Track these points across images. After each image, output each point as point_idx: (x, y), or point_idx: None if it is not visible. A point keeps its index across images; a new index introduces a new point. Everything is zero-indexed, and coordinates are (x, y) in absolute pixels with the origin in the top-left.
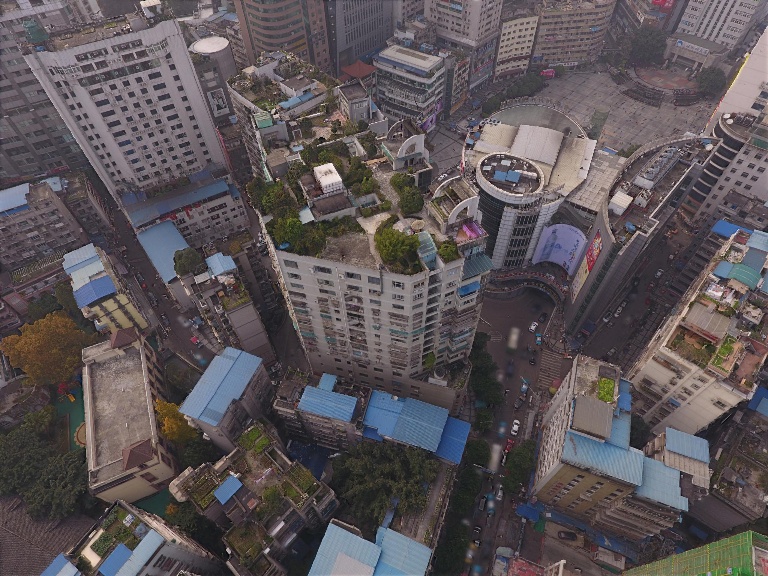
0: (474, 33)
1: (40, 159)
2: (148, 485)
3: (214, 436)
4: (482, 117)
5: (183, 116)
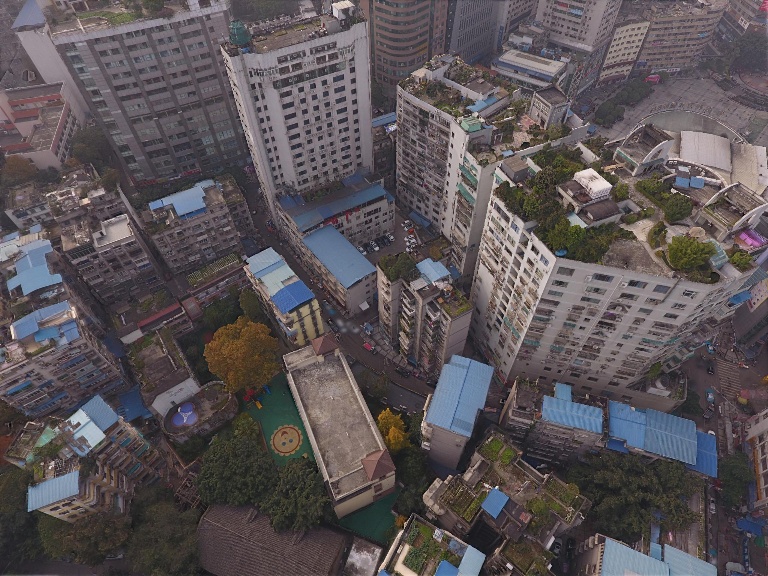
0: (592, 38)
1: (177, 162)
2: (371, 496)
3: (441, 446)
4: (595, 122)
5: (350, 119)
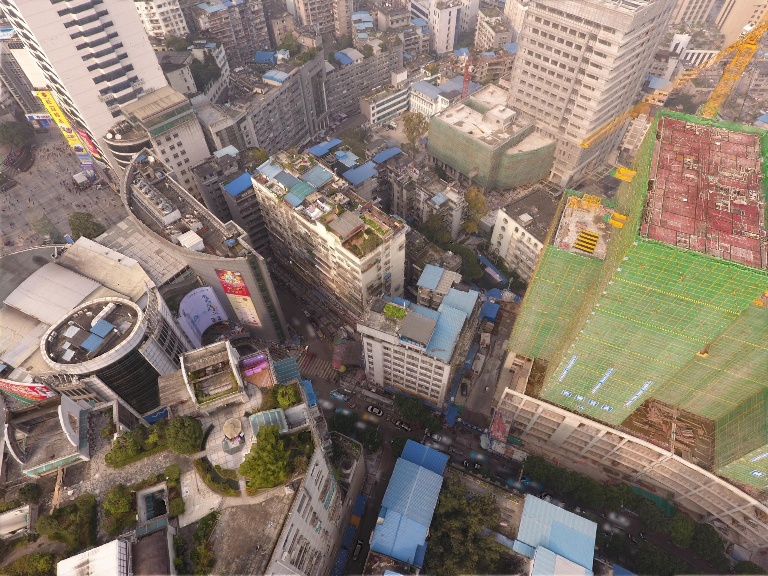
0: None
1: None
2: None
3: None
4: None
5: None
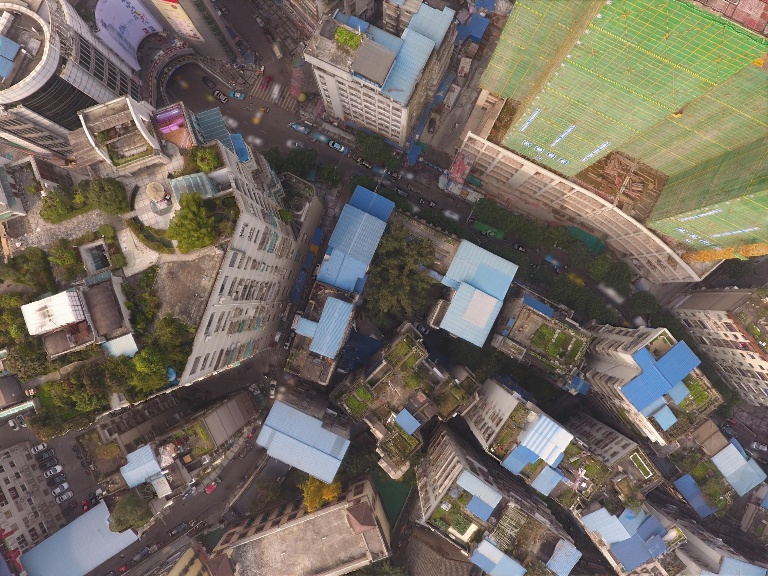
0: None
1: None
2: (377, 503)
3: None
4: None
5: None
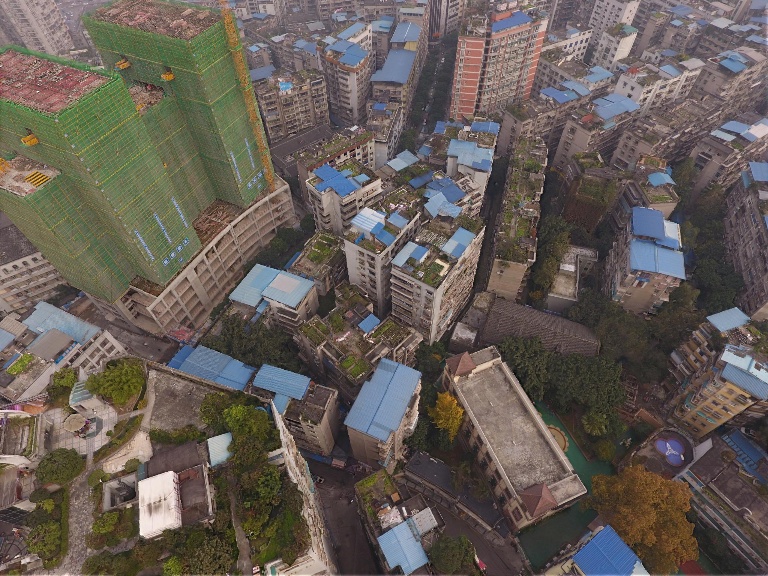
0: None
1: None
2: None
3: None
4: None
5: None
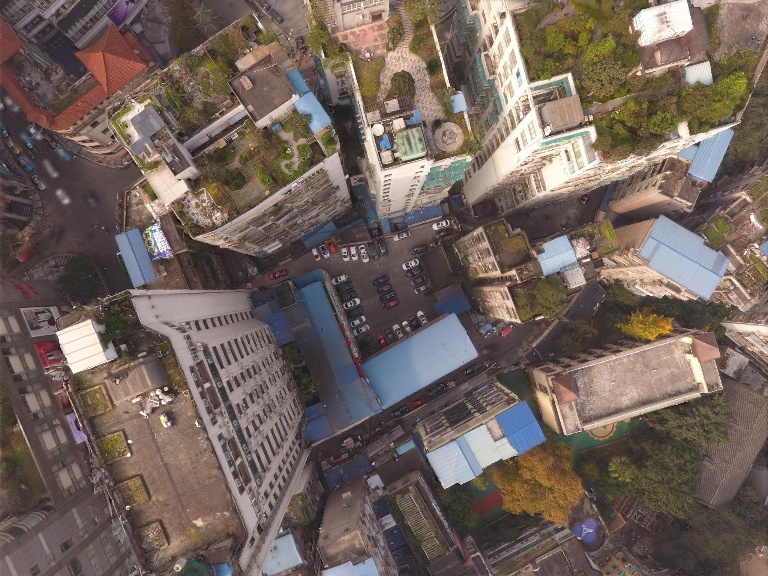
0: None
1: None
2: None
3: None
4: None
5: None
